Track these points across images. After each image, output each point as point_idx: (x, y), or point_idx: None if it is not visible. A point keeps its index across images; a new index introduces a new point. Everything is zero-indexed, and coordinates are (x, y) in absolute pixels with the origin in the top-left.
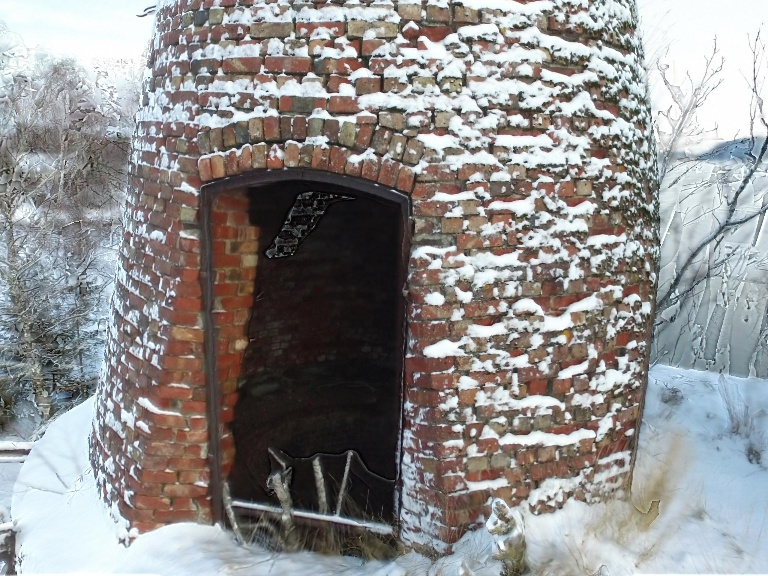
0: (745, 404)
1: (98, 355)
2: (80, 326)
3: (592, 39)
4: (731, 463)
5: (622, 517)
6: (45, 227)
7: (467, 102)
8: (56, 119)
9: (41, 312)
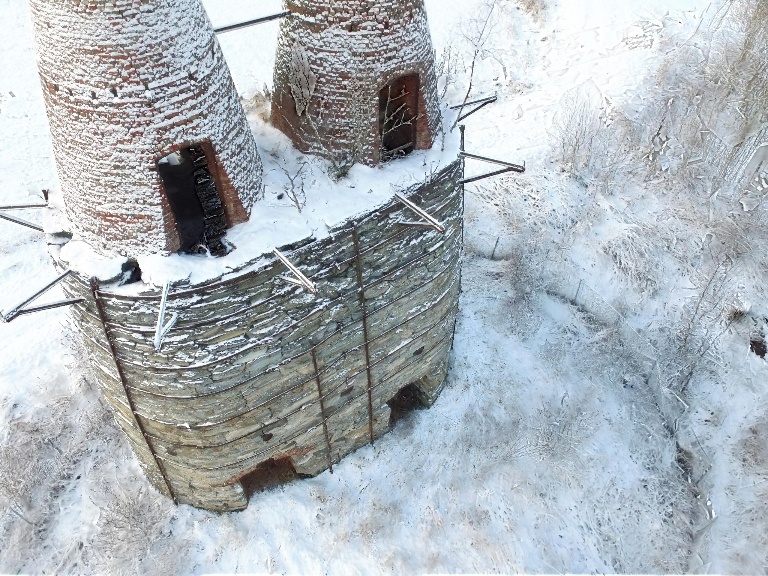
0: (273, 148)
1: None
2: None
3: None
4: None
5: (266, 114)
6: None
7: None
8: None
9: None
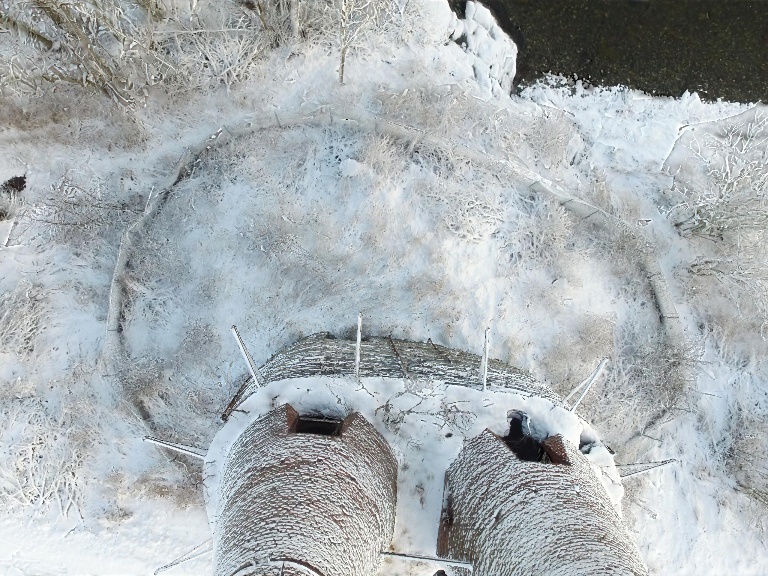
0: None
1: None
2: None
3: None
4: (416, 504)
5: None
6: None
7: None
8: None
9: None
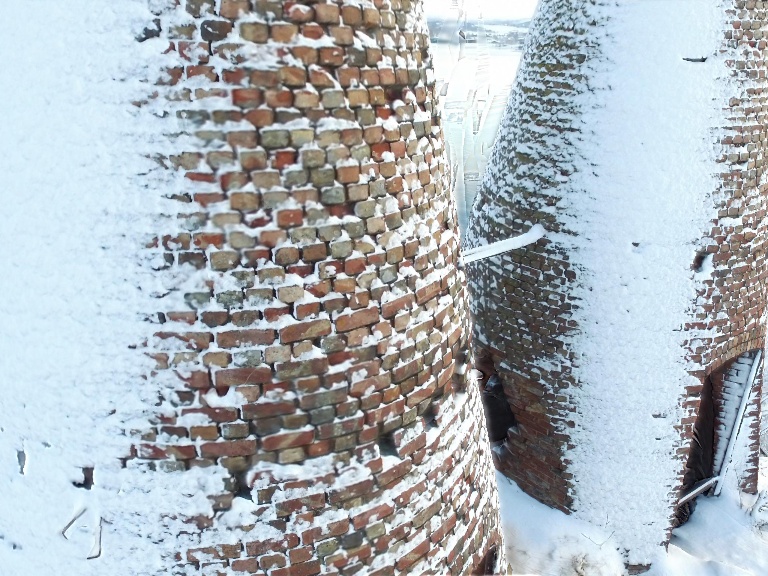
0: None
1: None
2: None
3: None
4: None
5: None
6: None
7: (492, 464)
8: None
9: None
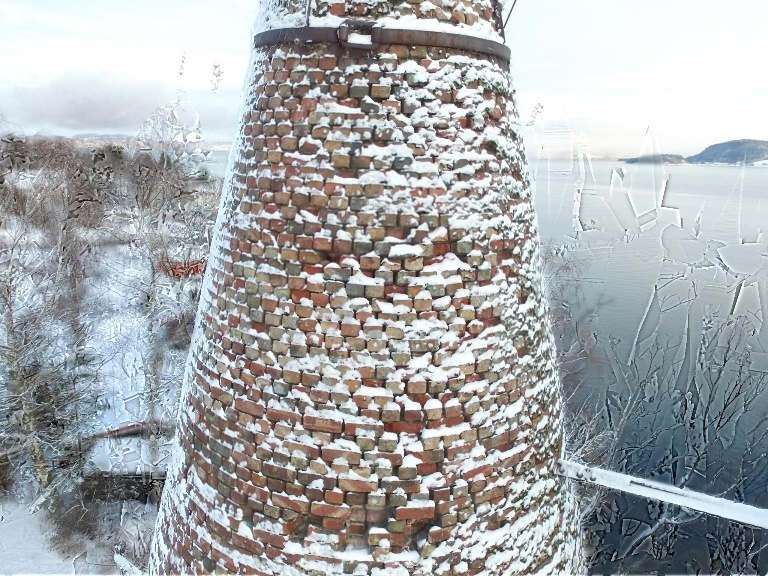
0: None
1: (96, 439)
2: (79, 410)
3: (522, 575)
4: None
5: None
6: (43, 307)
7: None
8: (55, 211)
9: (40, 394)
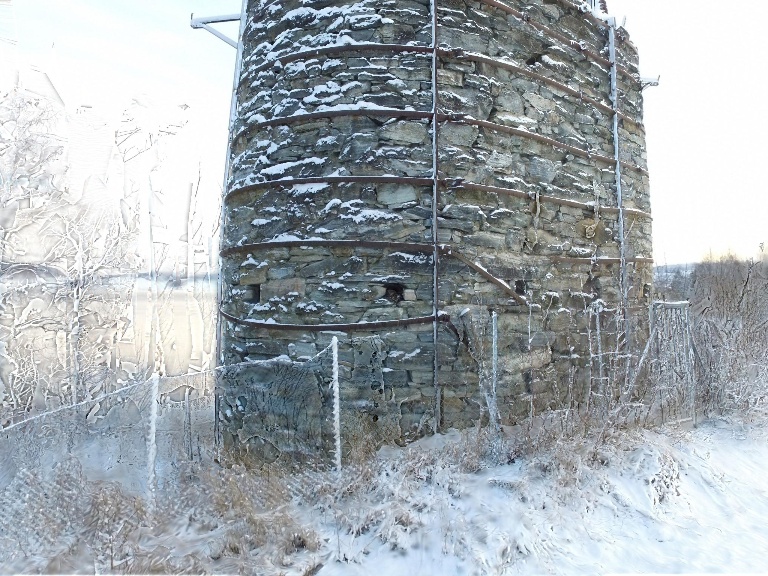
0: None
1: None
2: None
3: None
4: None
5: None
6: None
7: None
8: None
9: None
